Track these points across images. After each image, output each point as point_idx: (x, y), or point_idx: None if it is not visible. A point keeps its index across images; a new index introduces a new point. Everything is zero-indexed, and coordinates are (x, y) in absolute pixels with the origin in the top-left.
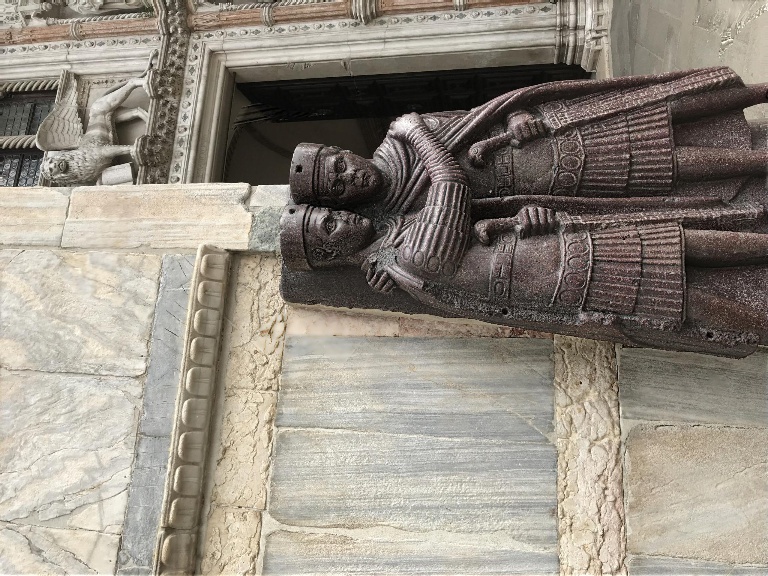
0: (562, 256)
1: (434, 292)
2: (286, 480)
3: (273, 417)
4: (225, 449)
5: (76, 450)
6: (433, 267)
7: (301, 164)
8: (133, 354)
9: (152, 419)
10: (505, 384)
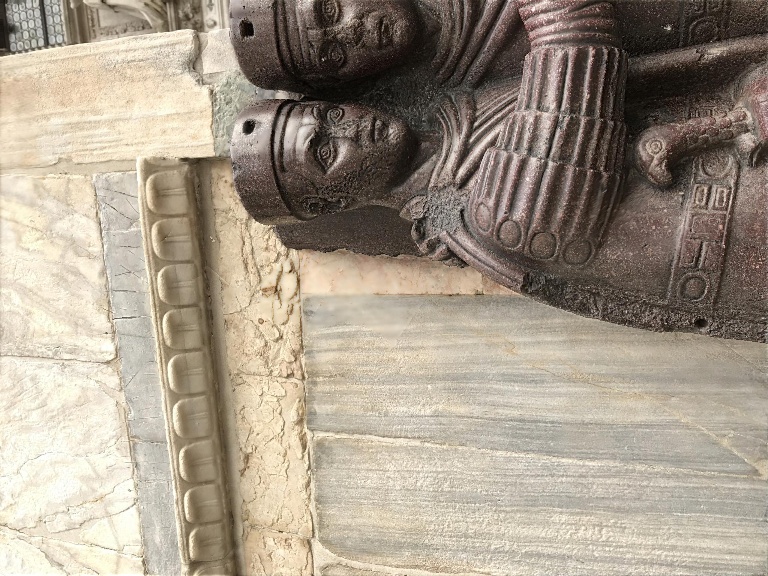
0: None
1: (546, 293)
2: (335, 503)
3: (303, 416)
4: (247, 455)
5: (63, 455)
6: (542, 251)
7: (248, 18)
8: (94, 331)
9: (142, 419)
10: (679, 376)
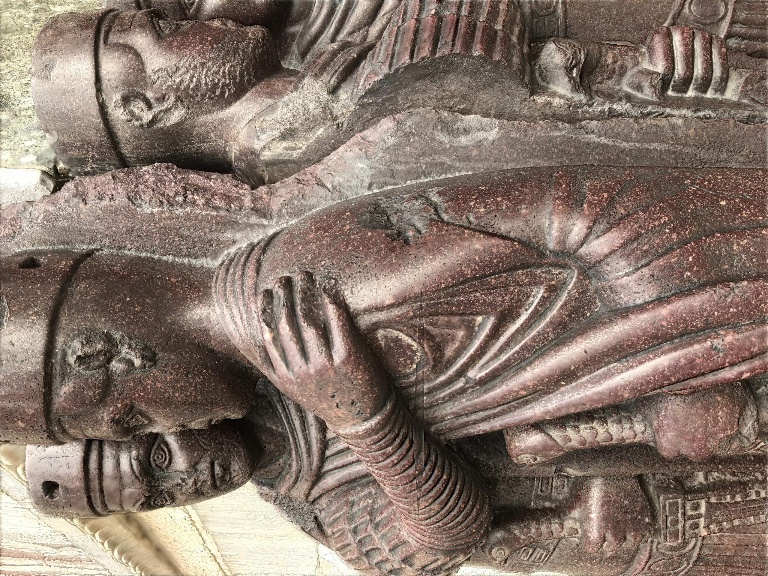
0: (632, 571)
1: None
2: None
3: None
4: None
5: None
6: None
7: None
8: None
9: None
10: None
